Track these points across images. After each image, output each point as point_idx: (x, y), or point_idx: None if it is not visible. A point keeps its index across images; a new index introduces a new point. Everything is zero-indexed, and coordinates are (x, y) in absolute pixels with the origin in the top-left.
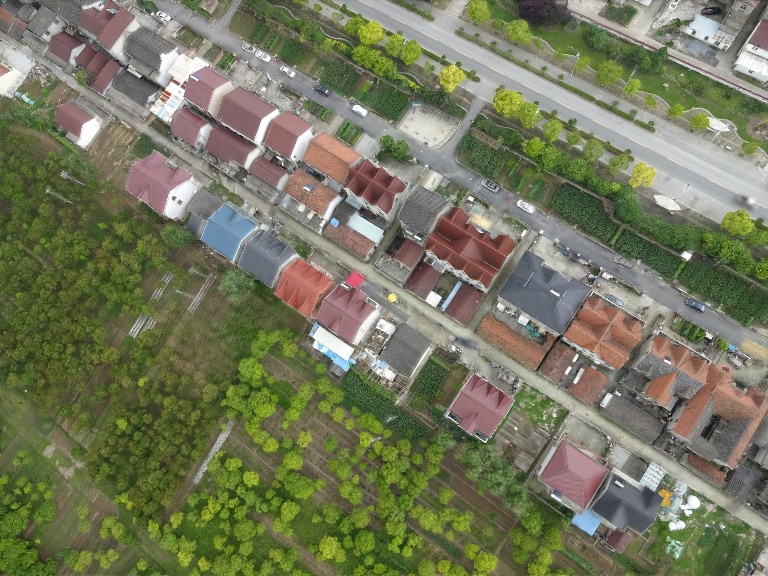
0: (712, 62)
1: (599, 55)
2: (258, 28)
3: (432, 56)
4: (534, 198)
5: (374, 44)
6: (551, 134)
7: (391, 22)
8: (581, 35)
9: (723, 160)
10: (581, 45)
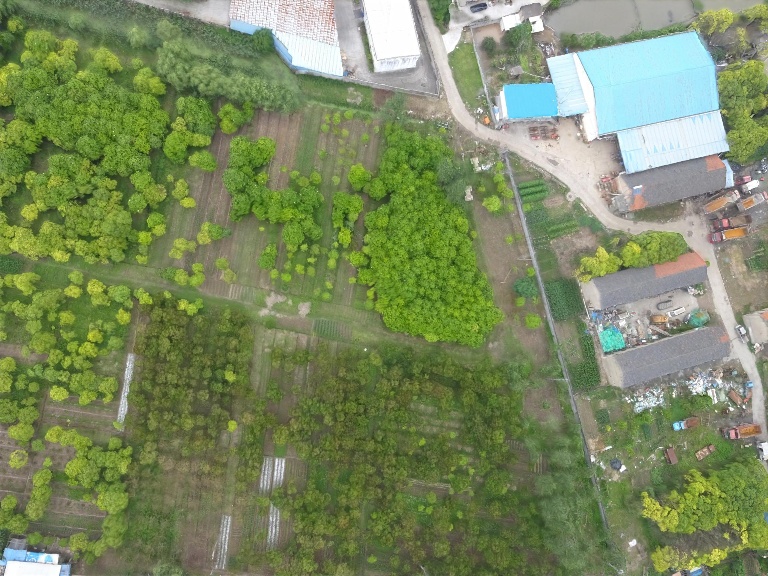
0: None
1: None
2: None
3: None
4: None
5: None
6: None
7: None
8: None
9: None
10: None
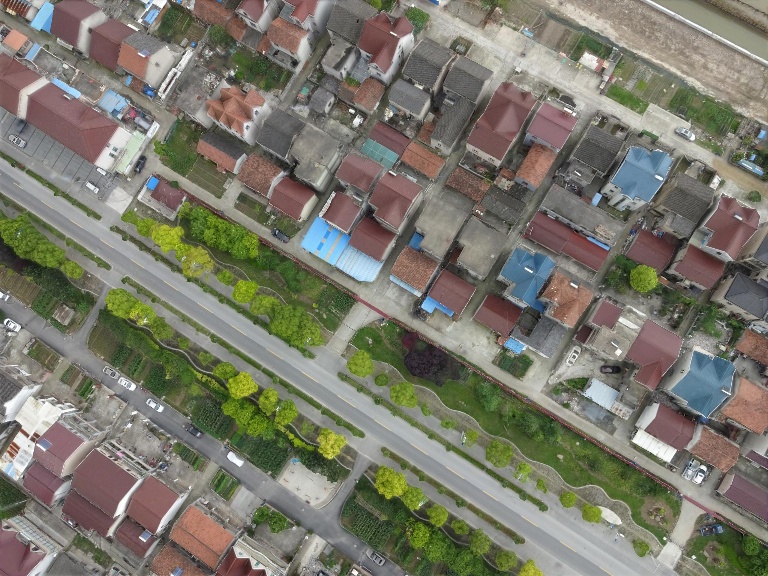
0: (609, 429)
1: (491, 415)
2: (120, 349)
3: (312, 404)
4: (421, 574)
5: (246, 396)
6: (436, 522)
7: (268, 356)
8: (473, 389)
9: (616, 546)
10: (473, 401)
